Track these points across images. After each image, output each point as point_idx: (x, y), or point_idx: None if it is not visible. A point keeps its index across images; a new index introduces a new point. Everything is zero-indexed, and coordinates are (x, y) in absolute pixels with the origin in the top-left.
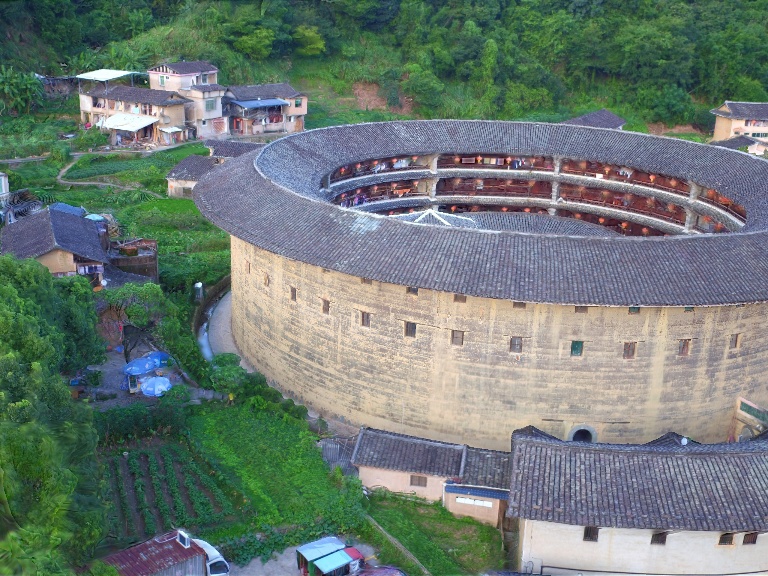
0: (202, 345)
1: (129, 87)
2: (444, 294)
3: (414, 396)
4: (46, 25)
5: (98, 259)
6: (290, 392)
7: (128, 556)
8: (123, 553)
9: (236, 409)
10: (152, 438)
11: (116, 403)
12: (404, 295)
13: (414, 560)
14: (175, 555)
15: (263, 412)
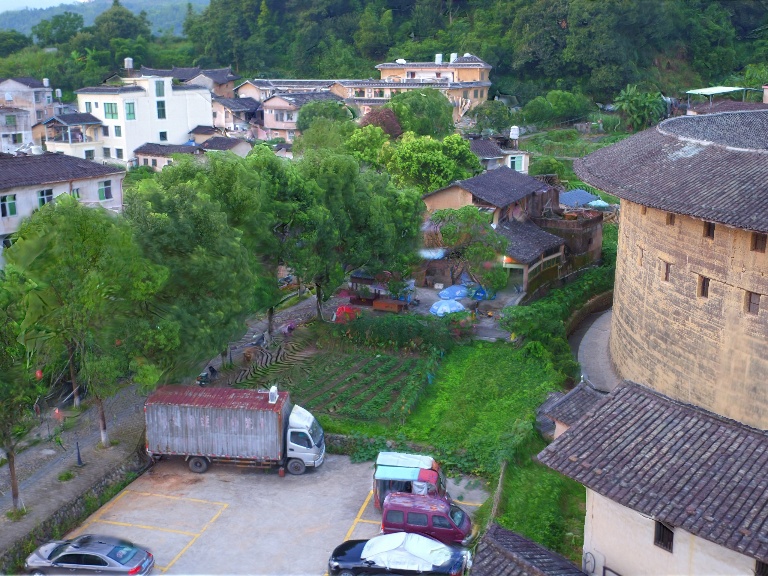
0: (589, 316)
1: (735, 102)
2: (740, 238)
3: (701, 379)
4: (699, 54)
5: (493, 202)
6: (615, 365)
7: (223, 391)
8: (224, 389)
9: (509, 349)
10: (409, 350)
11: (423, 323)
12: (700, 239)
13: (492, 512)
14: (254, 403)
15: (533, 358)
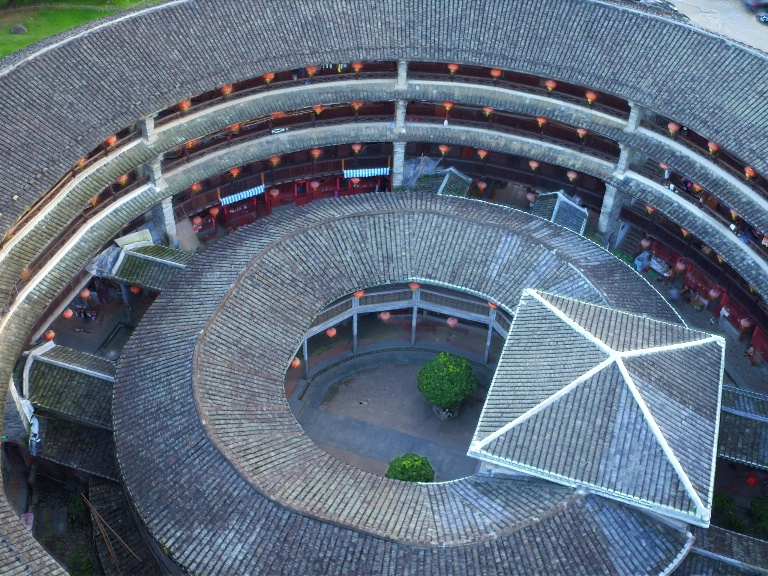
0: None
1: None
2: None
3: None
4: None
5: None
6: None
7: None
8: None
9: None
10: None
11: None
12: None
13: None
14: None
15: None
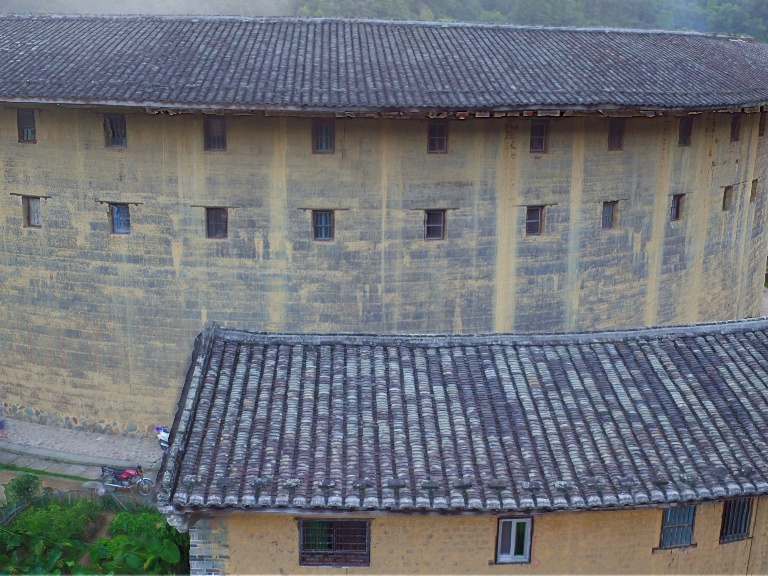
0: None
1: None
2: None
3: None
4: None
5: None
6: None
7: None
8: None
9: None
10: None
11: None
12: None
13: None
14: None
15: None
